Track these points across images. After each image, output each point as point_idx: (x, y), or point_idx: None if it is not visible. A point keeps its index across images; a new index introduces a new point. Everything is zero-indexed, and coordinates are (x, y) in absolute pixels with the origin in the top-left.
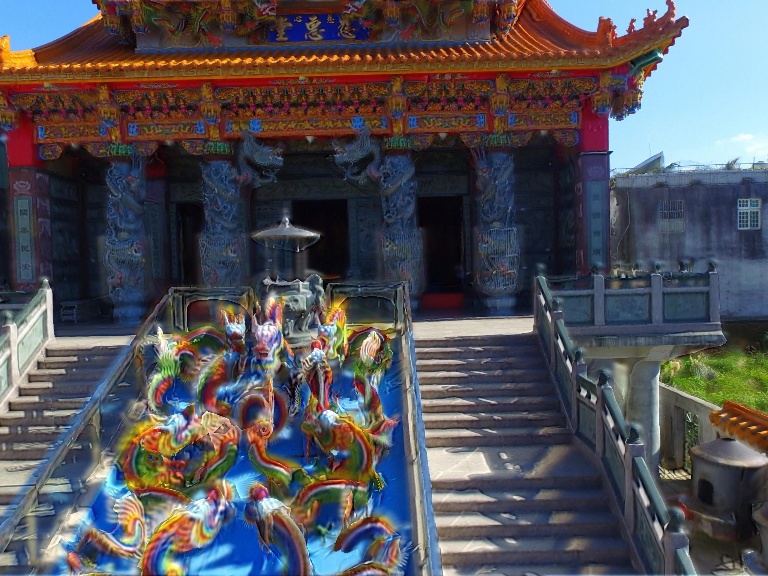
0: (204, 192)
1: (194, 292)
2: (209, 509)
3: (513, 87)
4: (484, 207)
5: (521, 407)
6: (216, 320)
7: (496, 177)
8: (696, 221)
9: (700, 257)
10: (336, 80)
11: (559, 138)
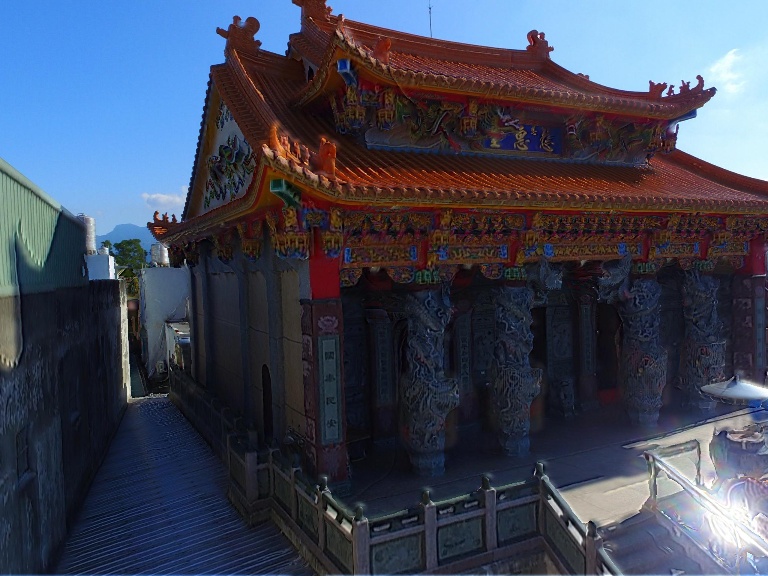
0: (505, 320)
1: (662, 454)
2: None
3: None
4: (699, 323)
5: None
6: (519, 455)
7: None
8: None
9: None
10: None
11: (733, 262)
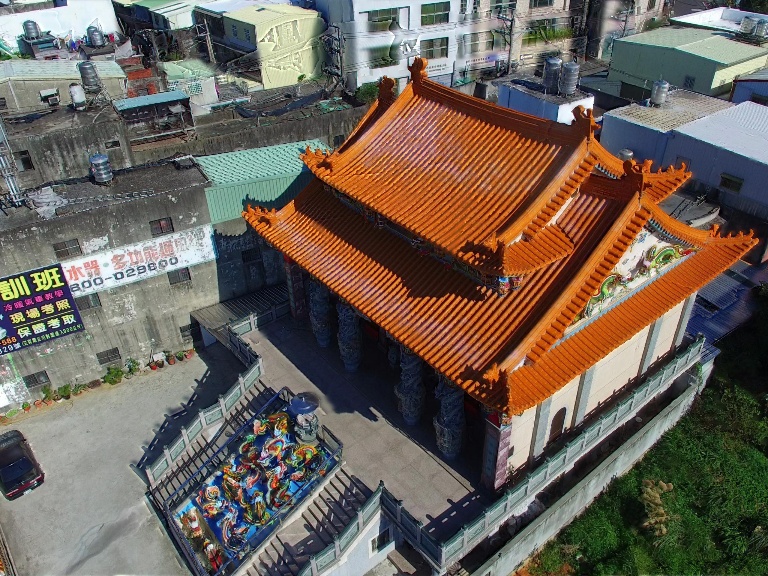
0: None
1: None
2: (220, 505)
3: None
4: None
5: None
6: (345, 367)
7: (441, 399)
8: None
9: None
10: None
11: None
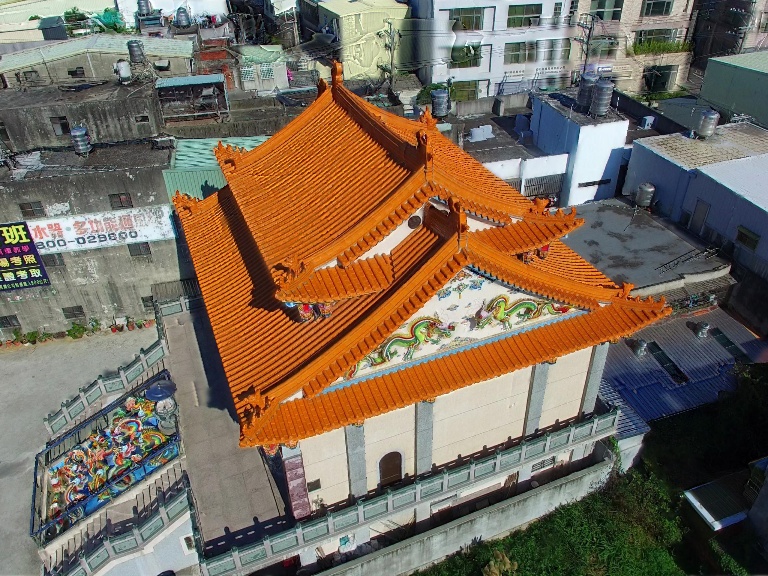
0: None
1: None
2: (75, 469)
3: None
4: None
5: None
6: None
7: None
8: None
9: None
10: None
11: None
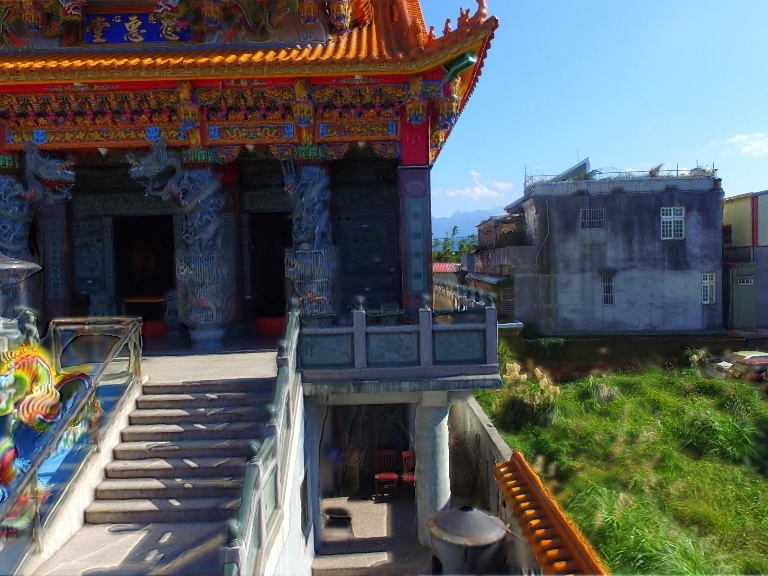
0: None
1: None
2: None
3: (317, 94)
4: None
5: (225, 471)
6: None
7: (302, 194)
8: (618, 230)
9: (622, 268)
10: (120, 86)
11: (378, 150)
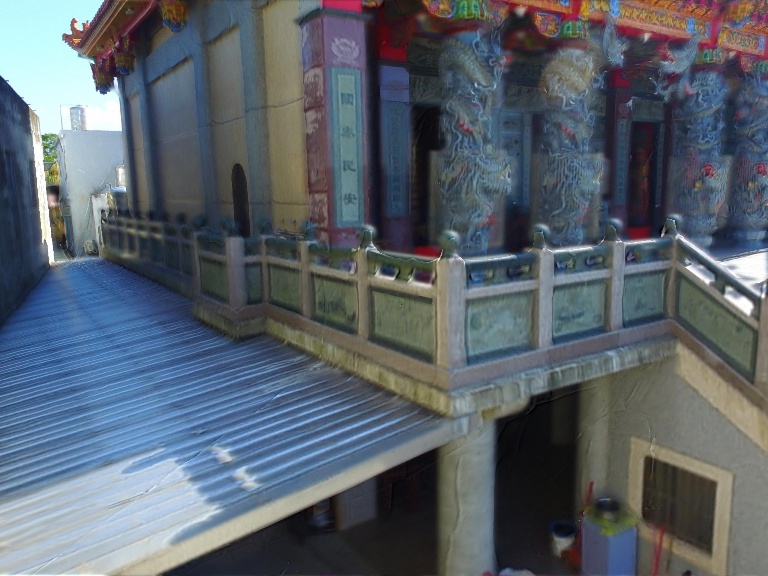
0: (562, 93)
1: None
2: None
3: None
4: (756, 136)
5: None
6: None
7: None
8: None
9: None
10: None
11: None
